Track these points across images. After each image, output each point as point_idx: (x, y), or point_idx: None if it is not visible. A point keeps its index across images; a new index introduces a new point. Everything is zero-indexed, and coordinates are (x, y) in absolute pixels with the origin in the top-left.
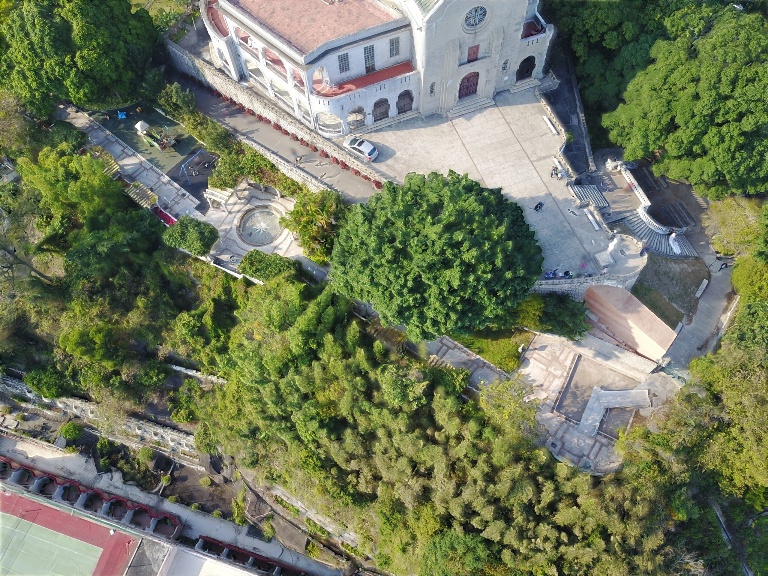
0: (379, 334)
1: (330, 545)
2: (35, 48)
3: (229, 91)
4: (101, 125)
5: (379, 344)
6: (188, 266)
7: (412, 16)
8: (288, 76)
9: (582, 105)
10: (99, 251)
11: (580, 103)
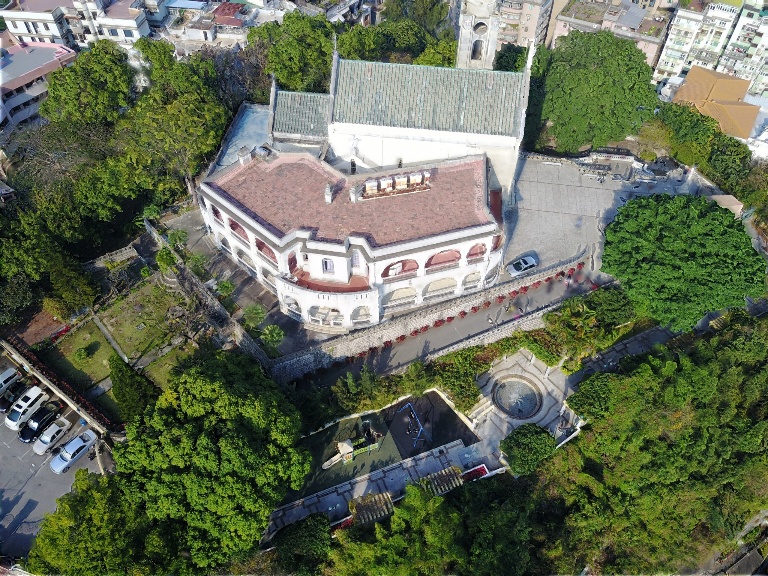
0: (682, 348)
1: (767, 532)
2: (239, 474)
3: (370, 342)
4: (282, 506)
5: (716, 338)
6: (540, 477)
7: (496, 146)
8: (463, 259)
9: (523, 149)
10: (526, 538)
11: (520, 149)
